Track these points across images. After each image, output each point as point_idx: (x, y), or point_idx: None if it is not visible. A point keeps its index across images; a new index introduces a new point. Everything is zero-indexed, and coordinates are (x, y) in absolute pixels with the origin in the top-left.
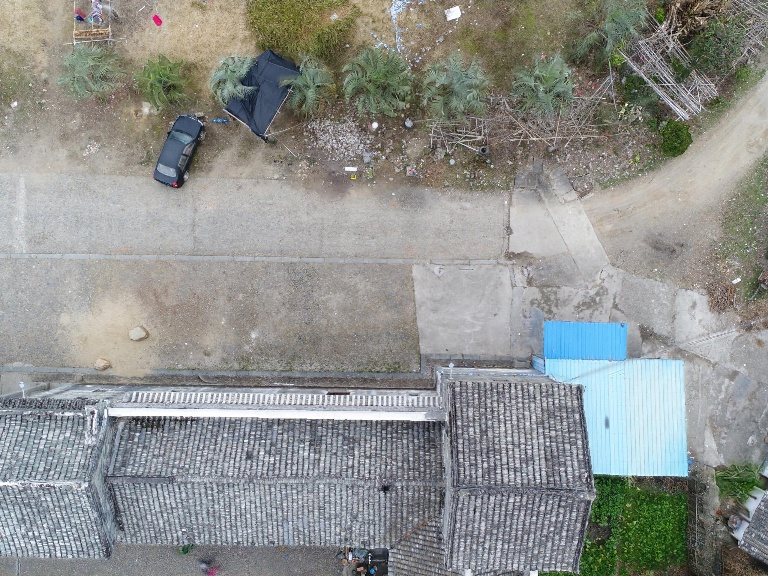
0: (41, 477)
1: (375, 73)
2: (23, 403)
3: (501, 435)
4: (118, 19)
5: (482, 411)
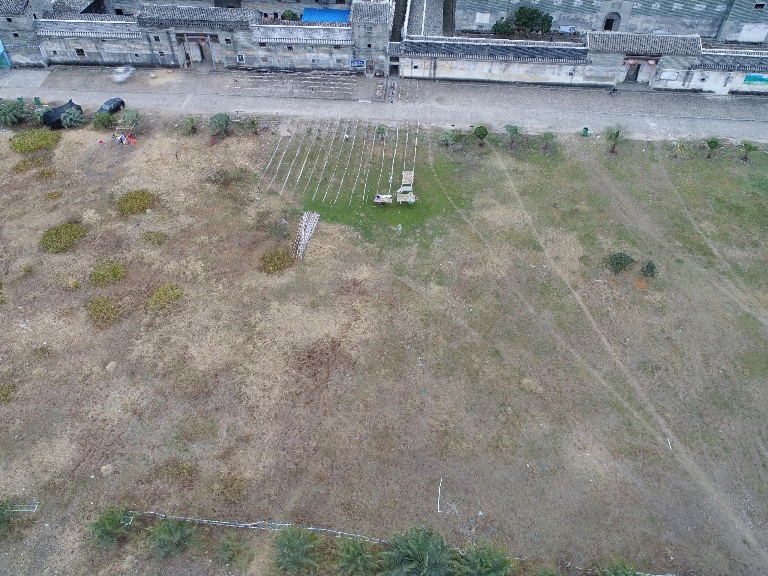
0: (156, 7)
1: (12, 108)
2: (163, 24)
3: (14, 2)
4: (118, 143)
5: (17, 7)
